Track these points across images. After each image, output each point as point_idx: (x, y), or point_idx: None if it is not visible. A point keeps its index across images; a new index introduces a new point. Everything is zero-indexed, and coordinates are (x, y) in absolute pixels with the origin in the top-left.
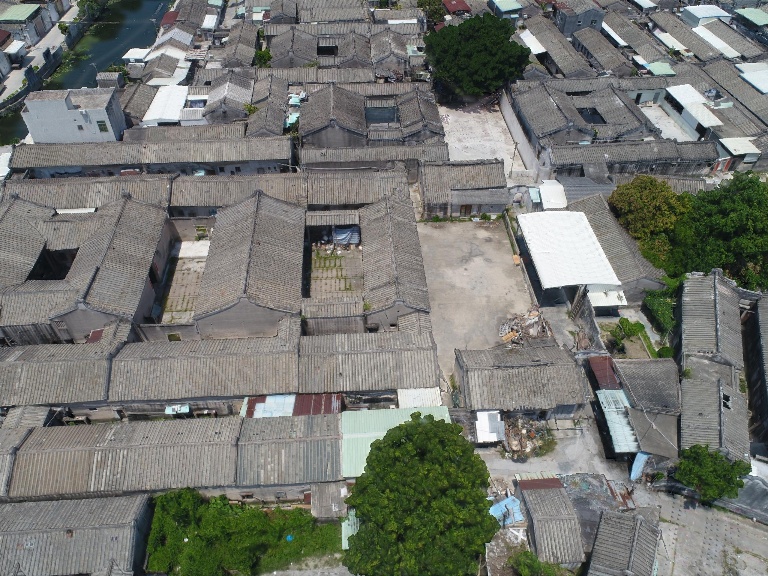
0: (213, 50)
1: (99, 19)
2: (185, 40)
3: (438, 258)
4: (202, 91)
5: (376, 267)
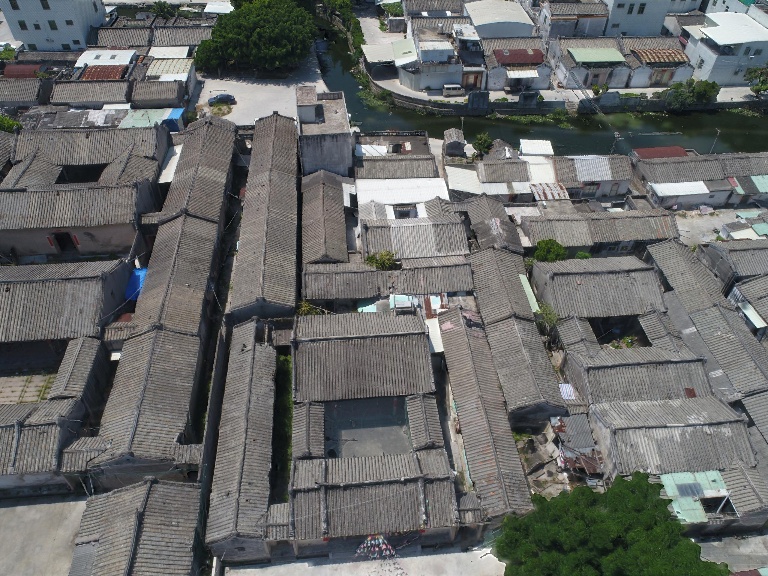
0: (572, 204)
1: (676, 112)
2: (587, 174)
3: (0, 534)
4: (433, 211)
5: None
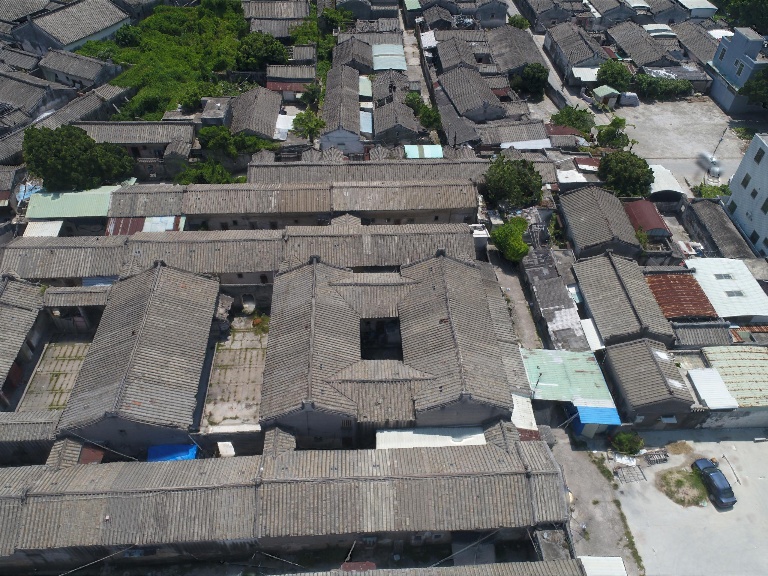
0: None
1: None
2: None
3: None
4: None
5: (8, 333)
